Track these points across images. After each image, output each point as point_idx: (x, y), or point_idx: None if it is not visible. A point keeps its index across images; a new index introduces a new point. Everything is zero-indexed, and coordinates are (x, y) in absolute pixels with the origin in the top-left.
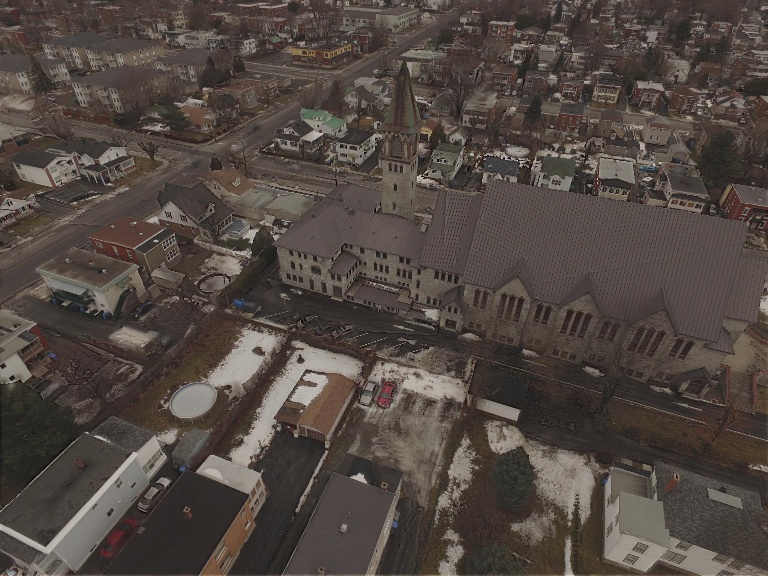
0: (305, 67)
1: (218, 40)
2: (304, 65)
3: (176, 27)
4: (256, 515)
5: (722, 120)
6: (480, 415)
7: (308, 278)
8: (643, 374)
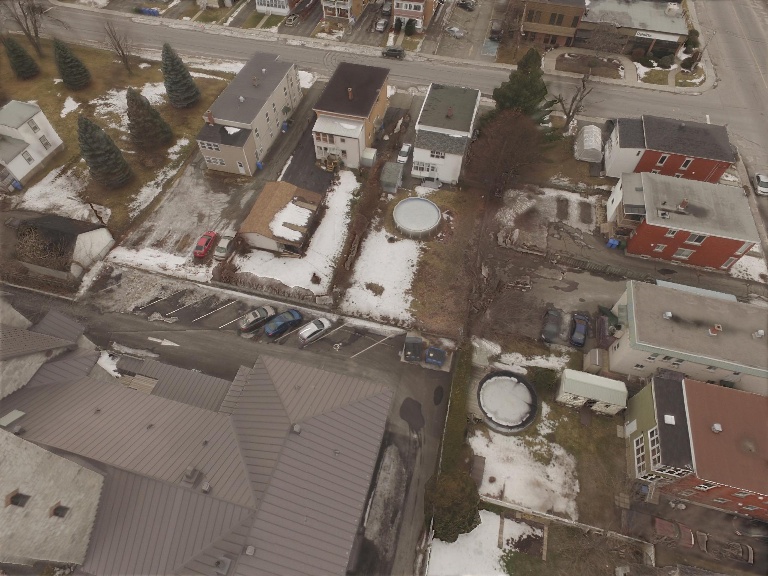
0: None
1: None
2: None
3: None
4: None
5: None
6: None
7: None
8: None
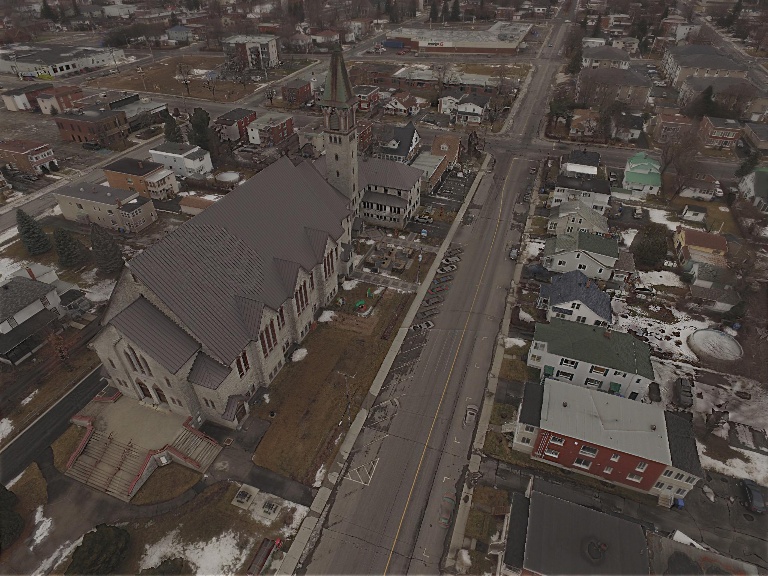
0: None
1: None
2: None
3: None
4: (154, 198)
5: None
6: None
7: None
8: None
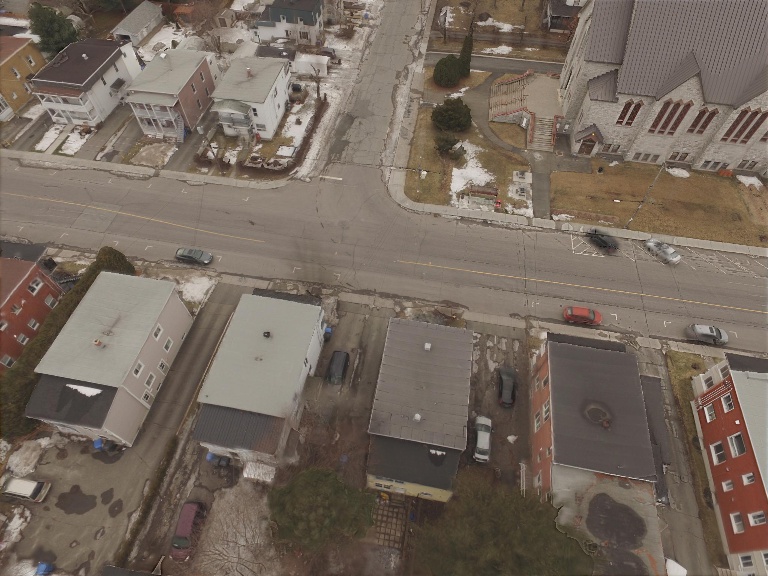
0: None
1: None
2: None
3: None
4: None
5: None
6: None
7: None
8: None
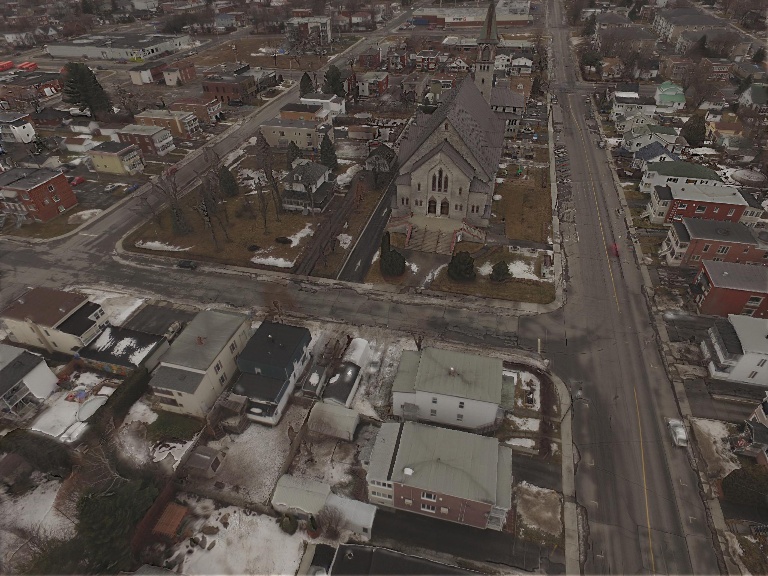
0: None
1: None
2: None
3: None
4: None
5: None
6: None
7: None
8: None
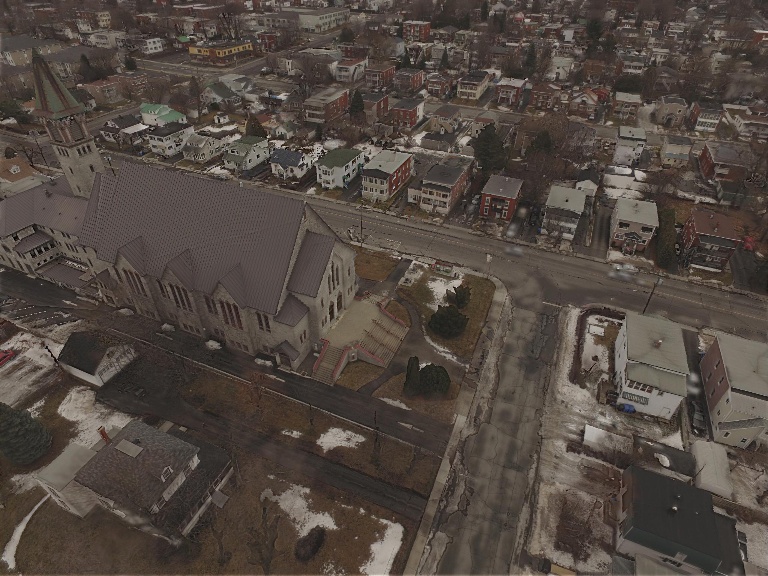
0: (199, 65)
1: (124, 39)
2: (200, 63)
3: (102, 27)
4: None
5: (573, 116)
6: (73, 381)
7: (6, 256)
8: (247, 347)
